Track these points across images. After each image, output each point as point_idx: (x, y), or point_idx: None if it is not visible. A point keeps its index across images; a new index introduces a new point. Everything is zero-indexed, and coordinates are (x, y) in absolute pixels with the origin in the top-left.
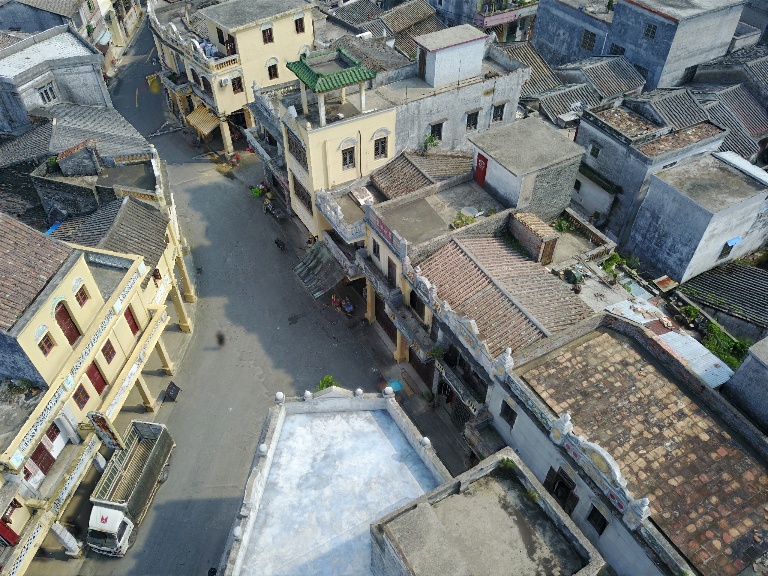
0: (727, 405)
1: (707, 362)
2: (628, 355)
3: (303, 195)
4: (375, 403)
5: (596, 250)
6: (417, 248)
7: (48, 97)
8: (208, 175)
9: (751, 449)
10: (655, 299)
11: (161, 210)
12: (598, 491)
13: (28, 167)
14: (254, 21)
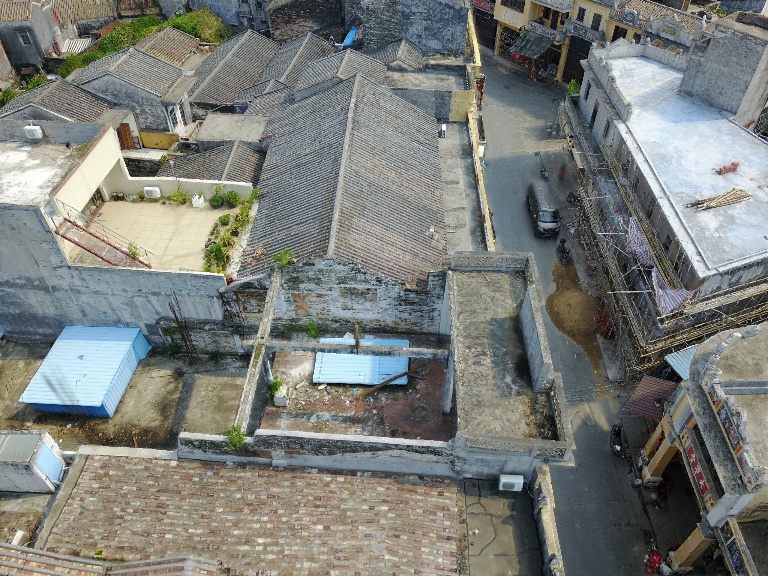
0: None
1: None
2: None
3: (513, 0)
4: (639, 50)
5: (711, 4)
6: None
7: None
8: None
9: None
10: None
11: None
12: None
13: None
14: None
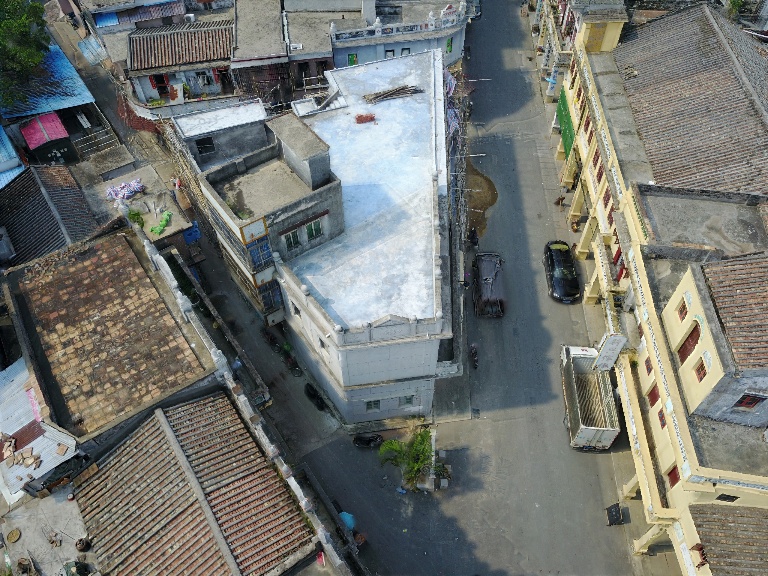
0: (23, 337)
1: (2, 395)
2: (80, 404)
3: None
4: None
5: None
6: (305, 549)
7: None
8: None
9: (26, 322)
10: None
11: None
12: None
13: None
14: None
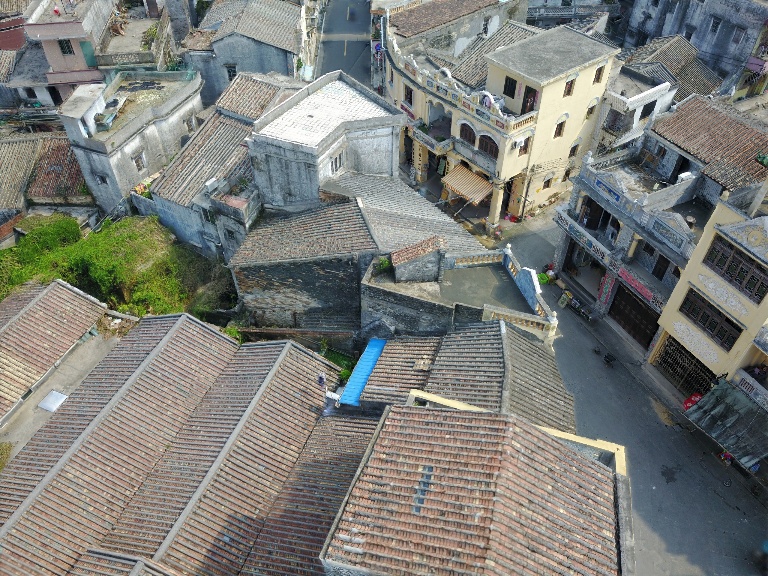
0: None
1: None
2: None
3: (708, 318)
4: None
5: None
6: None
7: (335, 166)
8: None
9: None
10: None
11: (546, 341)
12: None
13: (339, 265)
14: (564, 72)
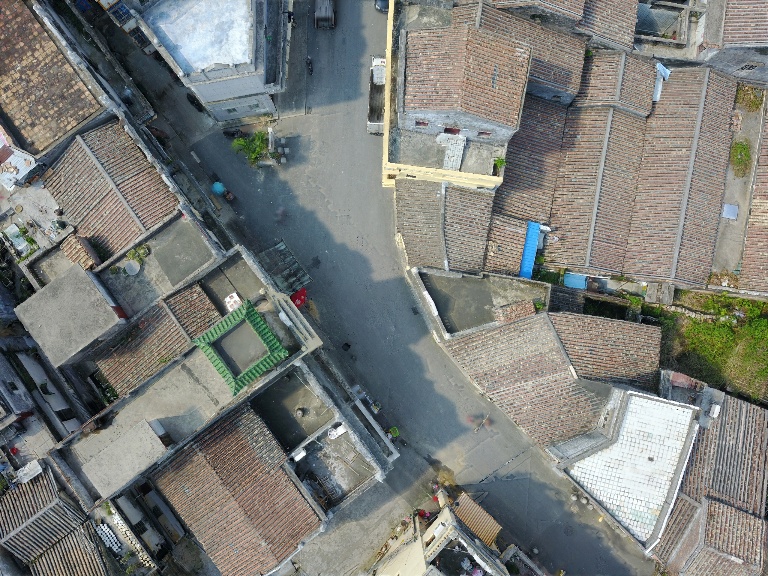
0: None
1: None
2: (29, 132)
3: None
4: None
5: (36, 255)
6: (173, 212)
7: None
8: (458, 461)
9: None
10: (3, 229)
11: None
12: (64, 36)
13: None
14: None
